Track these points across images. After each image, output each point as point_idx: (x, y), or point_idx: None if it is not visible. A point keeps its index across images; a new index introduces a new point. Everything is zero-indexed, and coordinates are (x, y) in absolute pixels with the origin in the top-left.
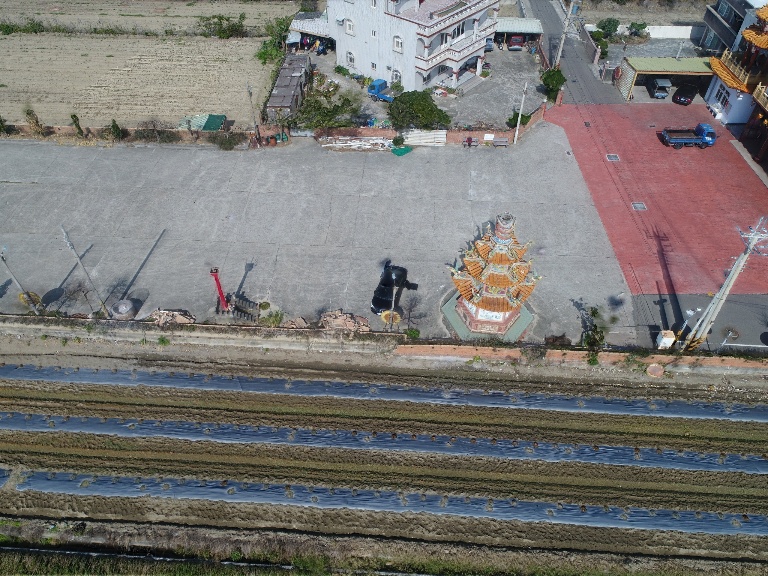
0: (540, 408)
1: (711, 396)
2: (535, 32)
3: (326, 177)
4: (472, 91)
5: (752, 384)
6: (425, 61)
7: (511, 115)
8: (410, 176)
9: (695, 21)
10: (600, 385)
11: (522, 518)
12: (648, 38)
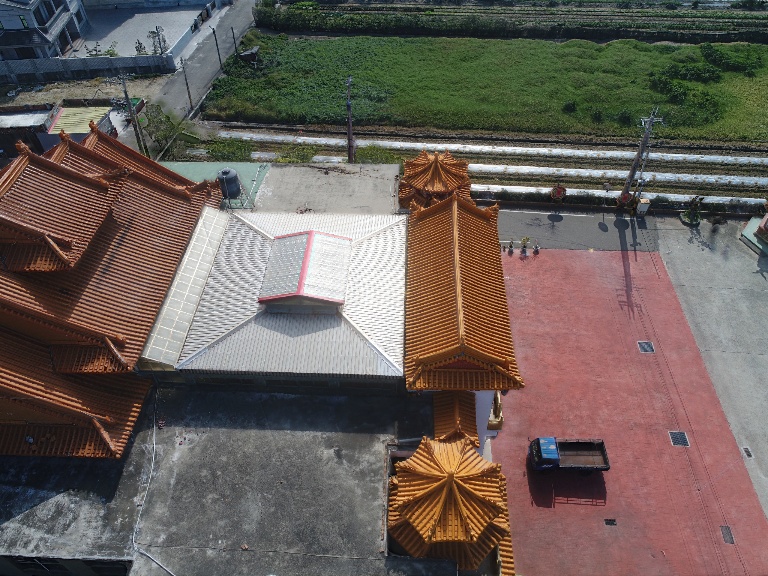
0: (717, 197)
1: None
2: None
3: None
4: None
5: None
6: None
7: None
8: None
9: None
10: None
11: (717, 156)
12: None
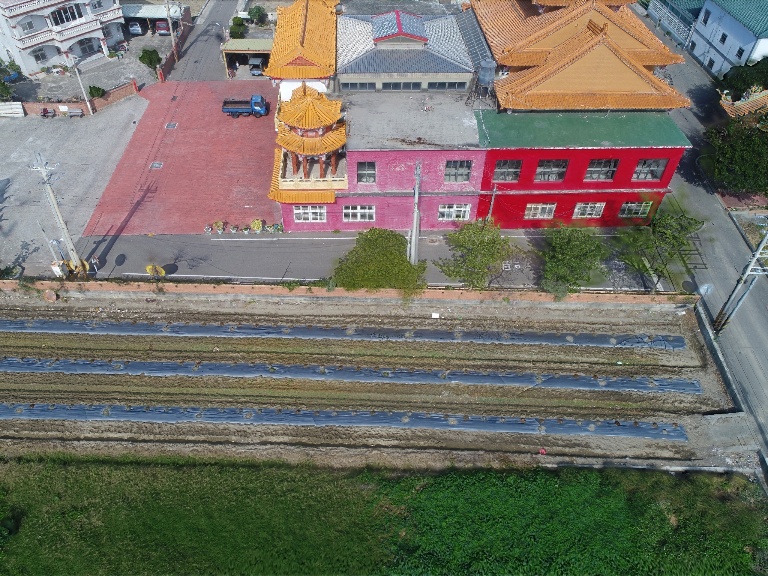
0: None
1: (90, 316)
2: None
3: None
4: (93, 70)
5: (133, 306)
6: (18, 40)
7: None
8: None
9: None
10: (0, 309)
11: None
12: None
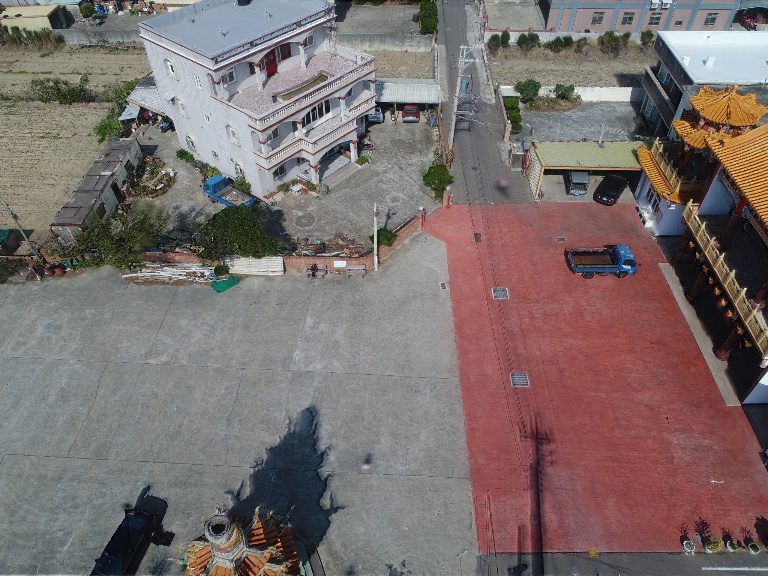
0: None
1: None
2: (431, 102)
3: (111, 330)
4: (342, 185)
5: None
6: (264, 159)
7: (382, 223)
8: (223, 327)
9: (643, 73)
10: None
11: None
12: (578, 102)
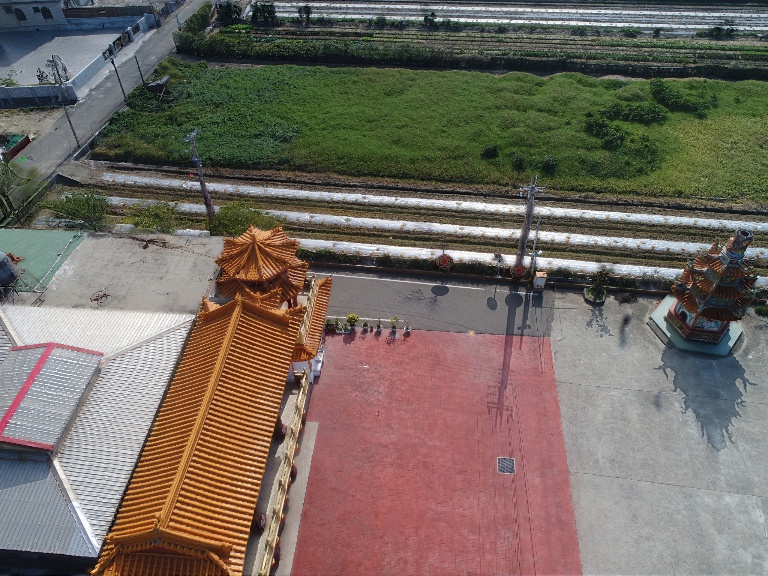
0: (636, 266)
1: None
2: None
3: None
4: None
5: None
6: None
7: None
8: None
9: None
10: None
11: (645, 215)
12: None
